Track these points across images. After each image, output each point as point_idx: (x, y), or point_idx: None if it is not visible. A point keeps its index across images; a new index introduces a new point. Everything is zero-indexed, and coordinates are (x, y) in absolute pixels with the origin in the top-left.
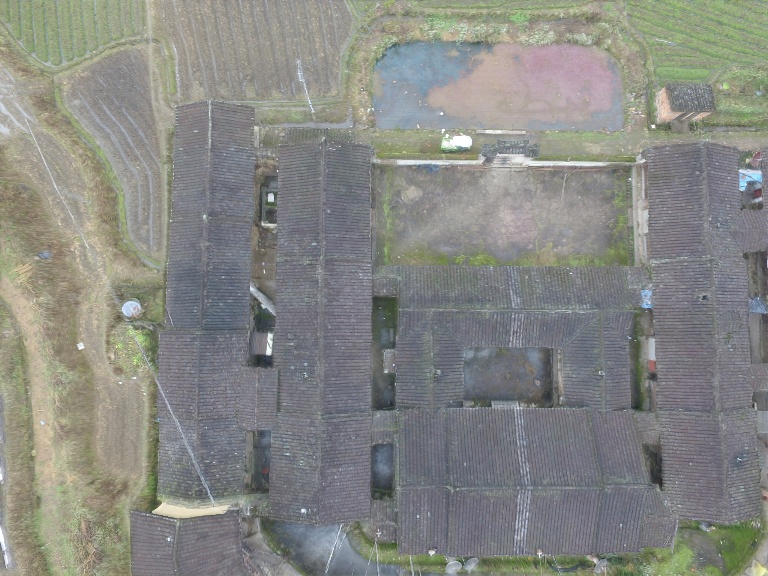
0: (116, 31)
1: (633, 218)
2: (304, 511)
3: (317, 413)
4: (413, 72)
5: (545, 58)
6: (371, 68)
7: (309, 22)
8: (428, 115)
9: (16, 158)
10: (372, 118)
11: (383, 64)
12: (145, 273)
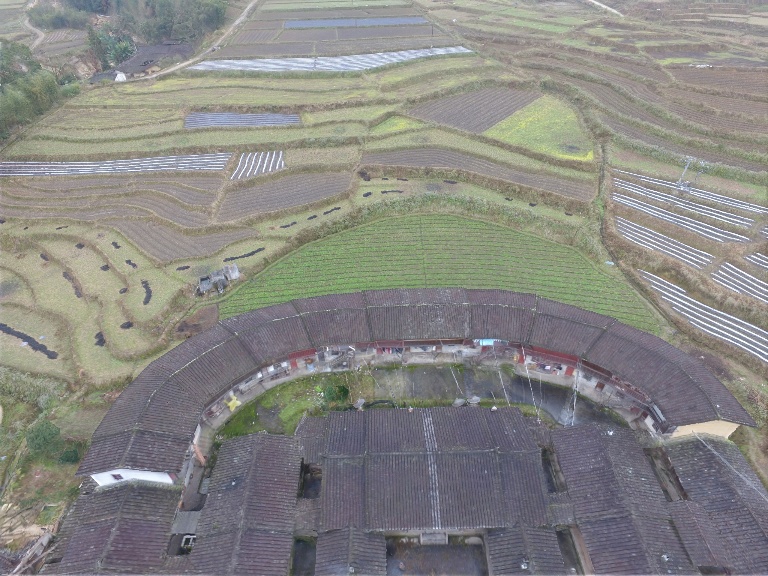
0: None
1: None
2: (610, 433)
3: (636, 517)
4: None
5: None
6: None
7: None
8: None
9: None
10: None
11: None
12: None
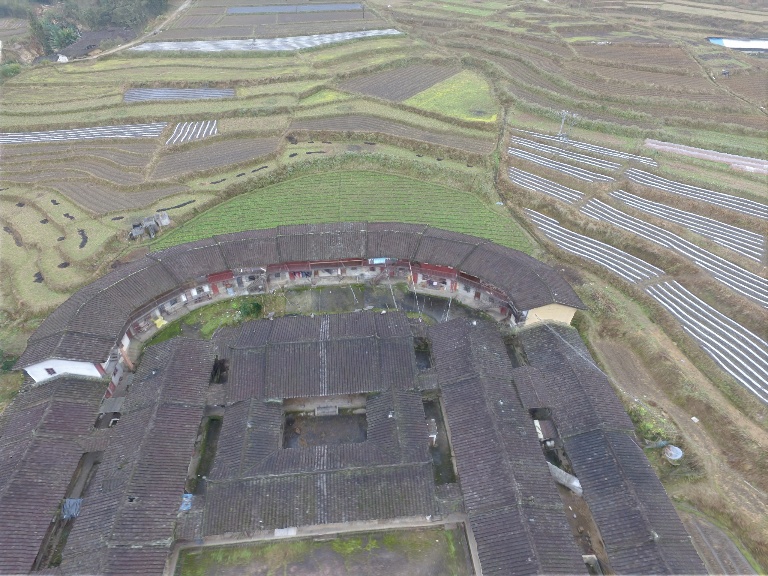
0: None
1: None
2: (474, 323)
3: (483, 377)
4: None
5: None
6: None
7: None
8: None
9: None
10: None
11: None
12: (684, 493)
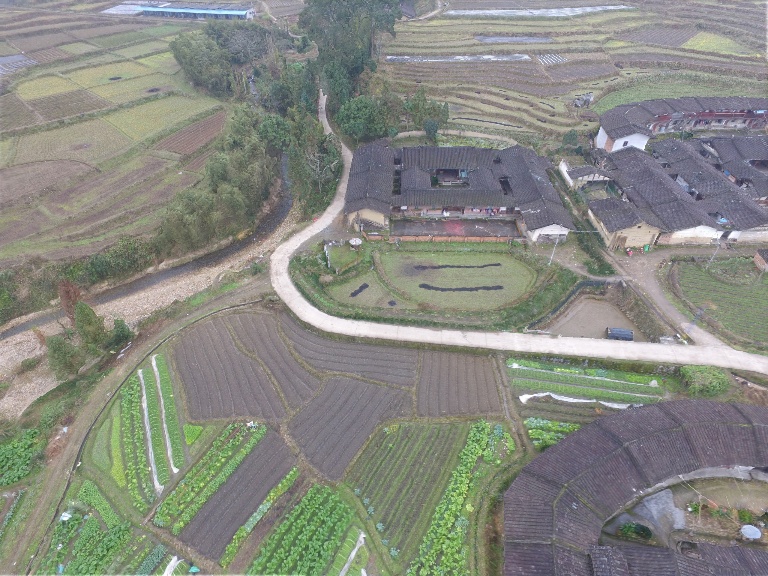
0: None
1: None
2: None
3: None
4: None
5: None
6: None
7: None
8: None
9: None
10: None
11: None
12: None
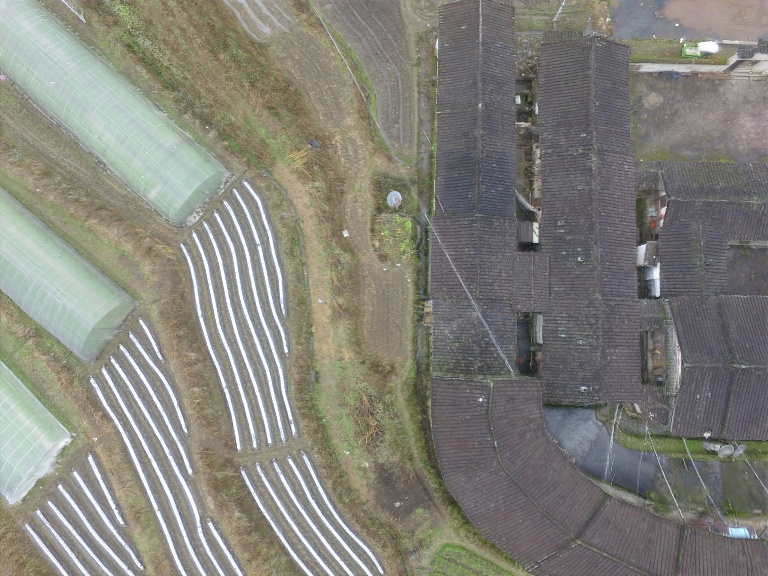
0: None
1: None
2: (586, 388)
3: (595, 295)
4: None
5: None
6: None
7: None
8: (663, 26)
9: (278, 55)
10: (610, 27)
11: None
12: (399, 168)
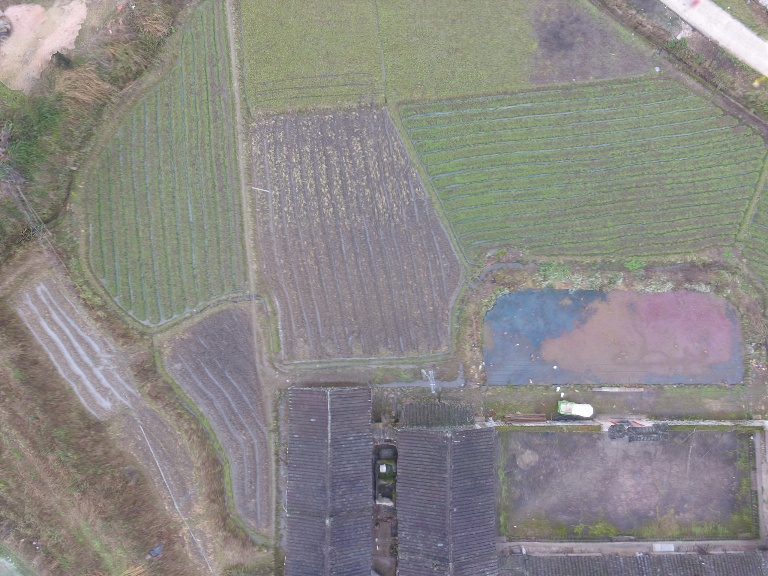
0: (217, 287)
1: (757, 482)
2: None
3: None
4: (524, 322)
5: (661, 306)
6: (482, 321)
7: (416, 272)
8: (541, 369)
9: (119, 436)
10: (484, 375)
11: (493, 314)
12: (255, 554)
